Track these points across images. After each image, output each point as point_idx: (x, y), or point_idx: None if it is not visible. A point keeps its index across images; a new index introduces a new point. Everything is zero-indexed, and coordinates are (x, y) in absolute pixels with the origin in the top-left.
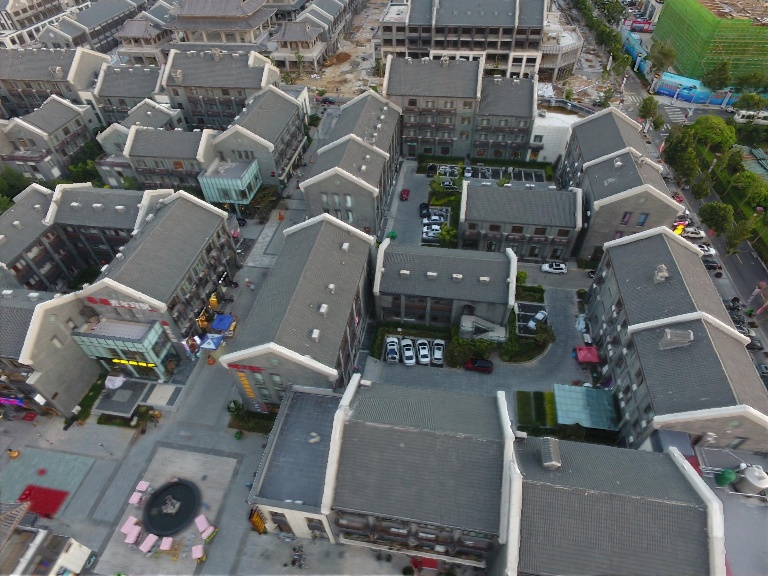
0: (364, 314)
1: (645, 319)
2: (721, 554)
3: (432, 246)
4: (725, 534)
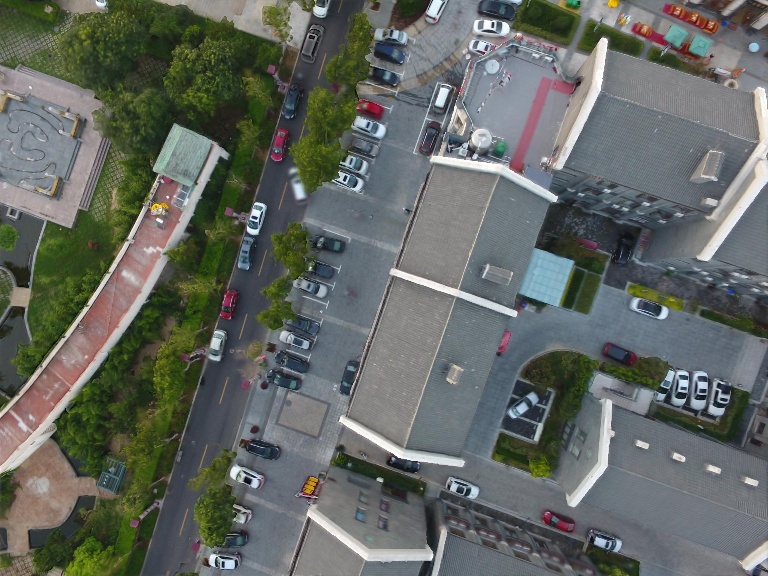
0: (759, 453)
1: (494, 321)
2: (601, 62)
3: (625, 571)
4: (525, 111)
